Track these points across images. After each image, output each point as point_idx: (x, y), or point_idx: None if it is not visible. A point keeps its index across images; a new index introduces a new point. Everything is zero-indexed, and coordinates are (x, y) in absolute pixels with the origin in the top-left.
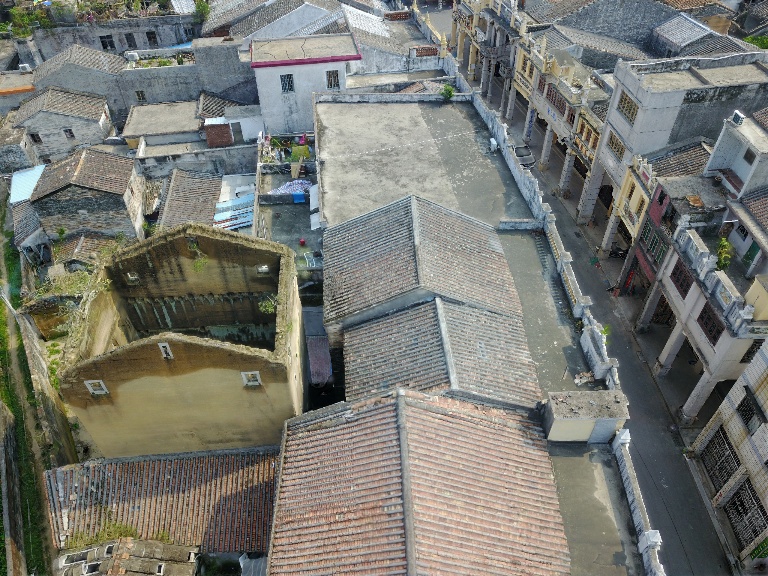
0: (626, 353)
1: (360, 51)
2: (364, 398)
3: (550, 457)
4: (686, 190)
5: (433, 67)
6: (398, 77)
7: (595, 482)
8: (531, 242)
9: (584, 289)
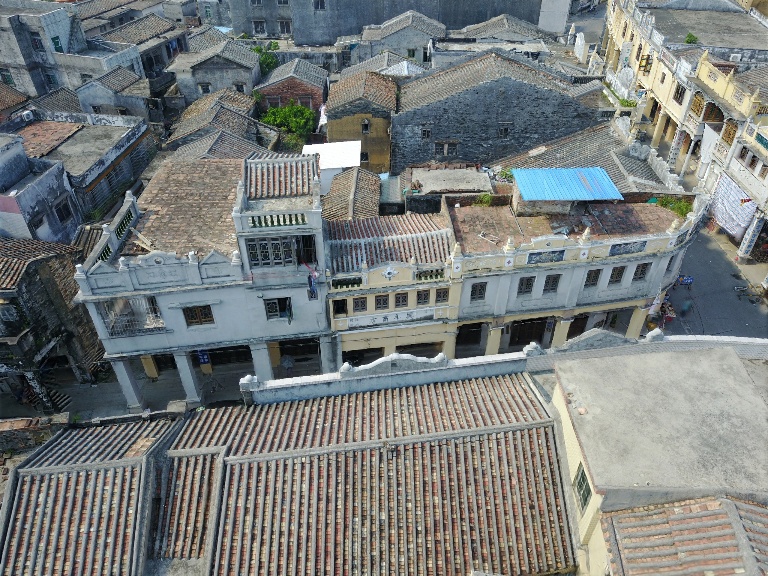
0: None
1: None
2: None
3: None
4: None
5: None
6: None
7: None
8: None
9: None
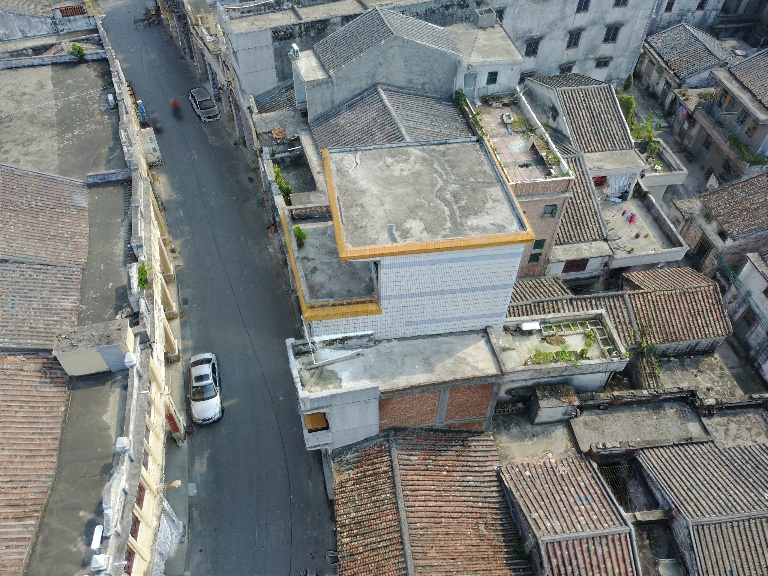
0: (272, 284)
1: None
2: None
3: (70, 391)
4: (275, 124)
5: (86, 27)
6: (46, 40)
7: (107, 406)
8: (121, 192)
9: (245, 230)
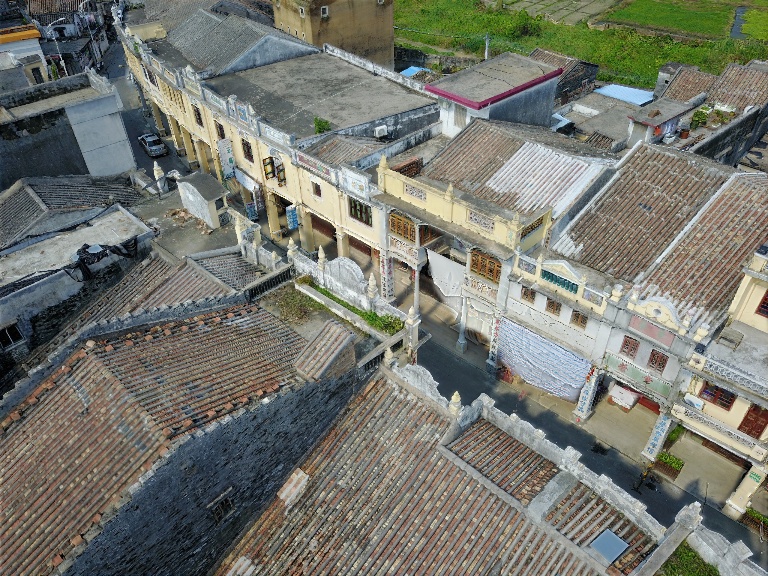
0: None
1: (440, 95)
2: (237, 5)
3: None
4: None
5: None
6: None
7: None
8: None
9: None
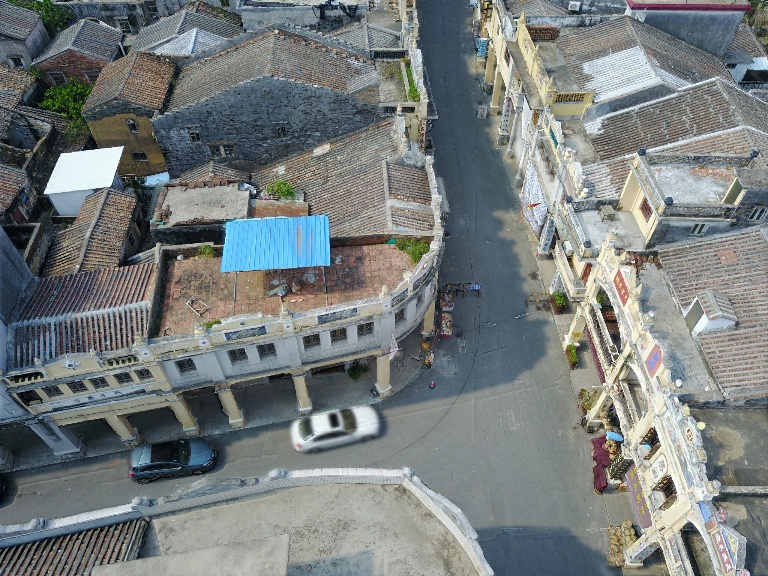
0: (418, 1)
1: None
2: None
3: None
4: None
5: None
6: None
7: None
8: None
9: (422, 26)
